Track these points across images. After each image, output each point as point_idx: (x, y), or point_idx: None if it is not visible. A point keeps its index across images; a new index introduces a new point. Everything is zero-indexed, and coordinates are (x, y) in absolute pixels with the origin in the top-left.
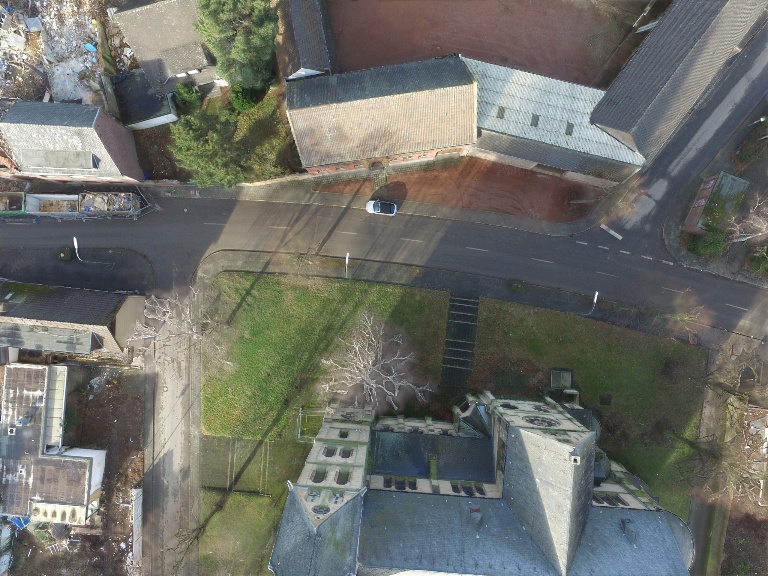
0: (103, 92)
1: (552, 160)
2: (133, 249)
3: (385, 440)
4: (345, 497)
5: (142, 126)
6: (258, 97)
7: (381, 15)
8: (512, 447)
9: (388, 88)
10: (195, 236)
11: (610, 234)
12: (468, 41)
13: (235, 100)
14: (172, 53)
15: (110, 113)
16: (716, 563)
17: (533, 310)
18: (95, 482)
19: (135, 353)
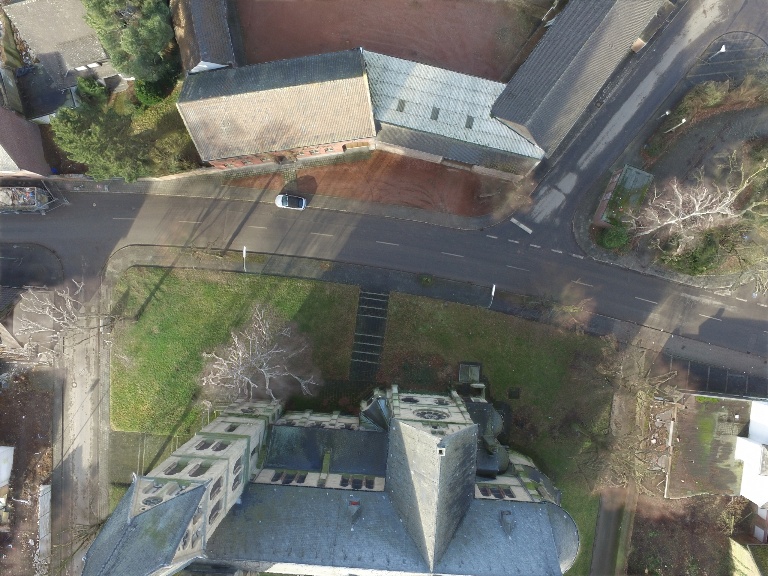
0: (2, 85)
1: (454, 153)
2: (41, 244)
3: (281, 434)
4: (187, 489)
5: (48, 120)
6: (165, 91)
7: (289, 9)
8: (393, 440)
9: (281, 81)
10: (104, 231)
11: (520, 228)
12: (377, 35)
13: (139, 94)
14: (69, 46)
15: (9, 107)
16: (623, 556)
17: (443, 304)
18: (1, 479)
19: (41, 349)
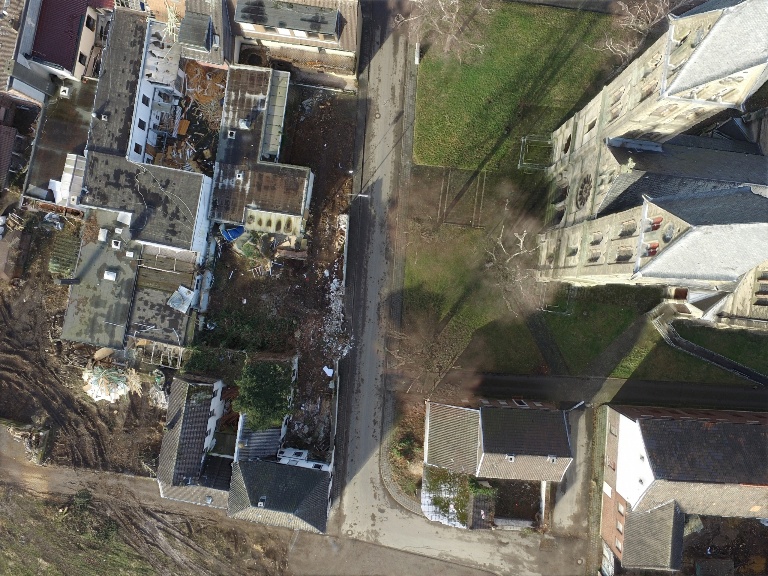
0: None
1: None
2: None
3: None
4: None
5: None
6: None
7: None
8: None
9: None
10: None
11: None
12: None
13: None
14: None
15: None
16: None
17: None
18: (307, 199)
19: None
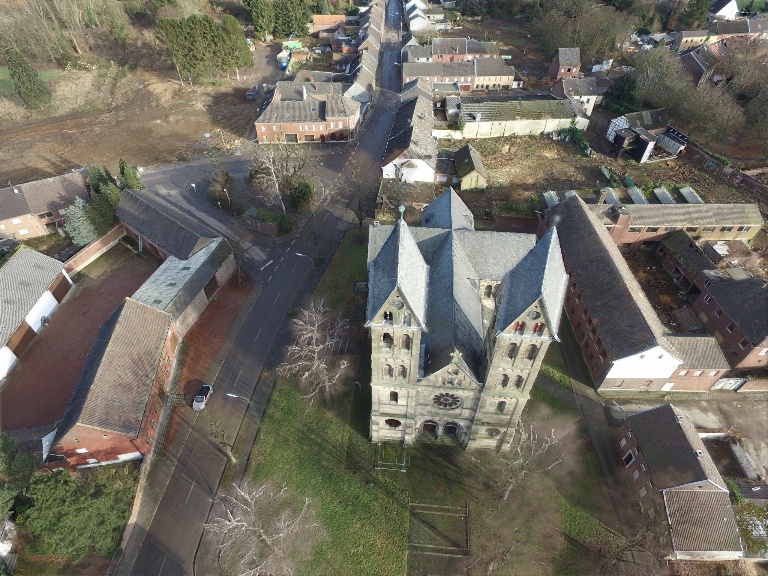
0: None
1: (204, 279)
2: None
3: None
4: None
5: None
6: None
7: (34, 394)
8: None
9: (100, 354)
10: None
11: (268, 266)
12: (94, 336)
13: None
14: None
15: None
16: (476, 223)
17: None
18: None
19: None
